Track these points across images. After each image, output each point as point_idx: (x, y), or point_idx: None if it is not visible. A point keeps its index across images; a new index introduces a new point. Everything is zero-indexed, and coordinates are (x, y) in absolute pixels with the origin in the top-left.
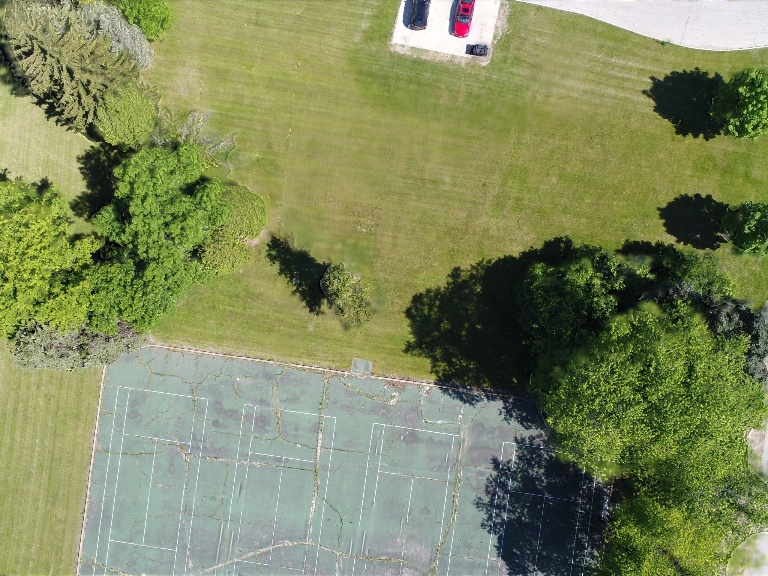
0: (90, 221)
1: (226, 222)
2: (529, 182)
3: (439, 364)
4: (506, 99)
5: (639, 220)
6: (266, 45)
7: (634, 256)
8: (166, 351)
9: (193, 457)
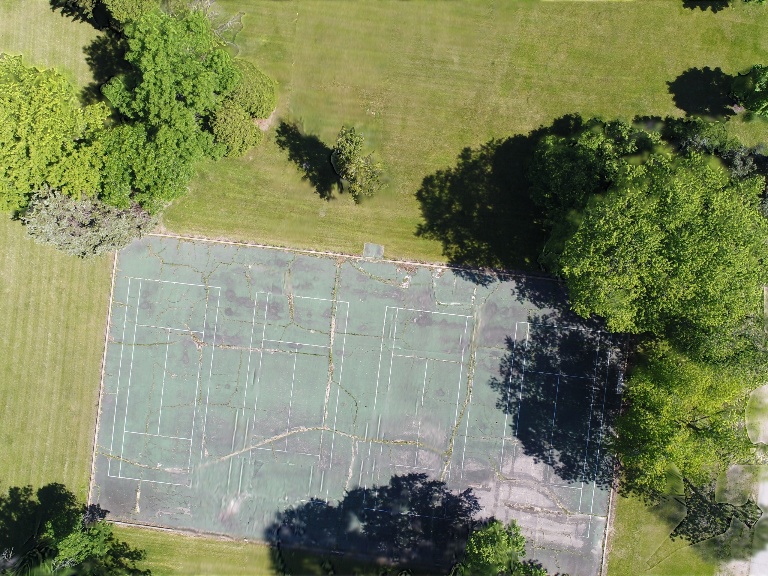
0: None
1: (237, 89)
2: (538, 60)
3: (451, 246)
4: None
5: (648, 95)
6: None
7: None
8: (177, 241)
9: (206, 346)
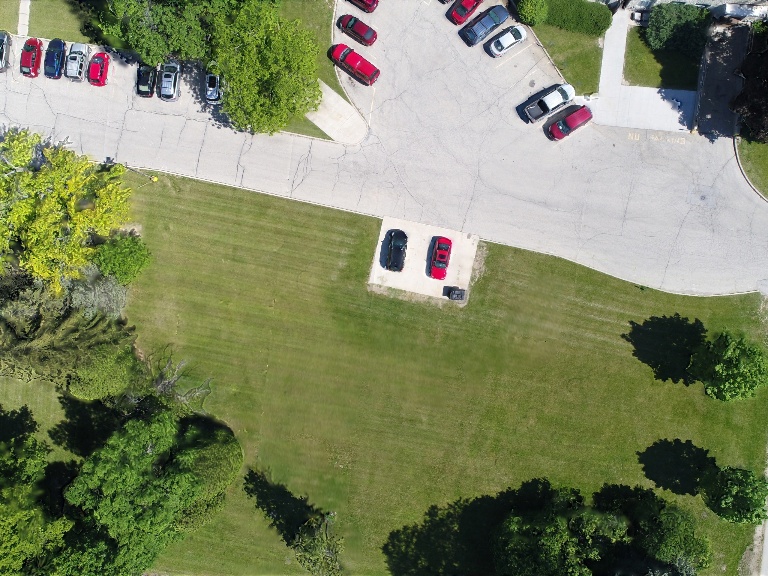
0: (63, 493)
1: None
2: (507, 423)
3: None
4: (483, 341)
5: (618, 464)
6: (243, 281)
7: (613, 499)
8: None
9: None
